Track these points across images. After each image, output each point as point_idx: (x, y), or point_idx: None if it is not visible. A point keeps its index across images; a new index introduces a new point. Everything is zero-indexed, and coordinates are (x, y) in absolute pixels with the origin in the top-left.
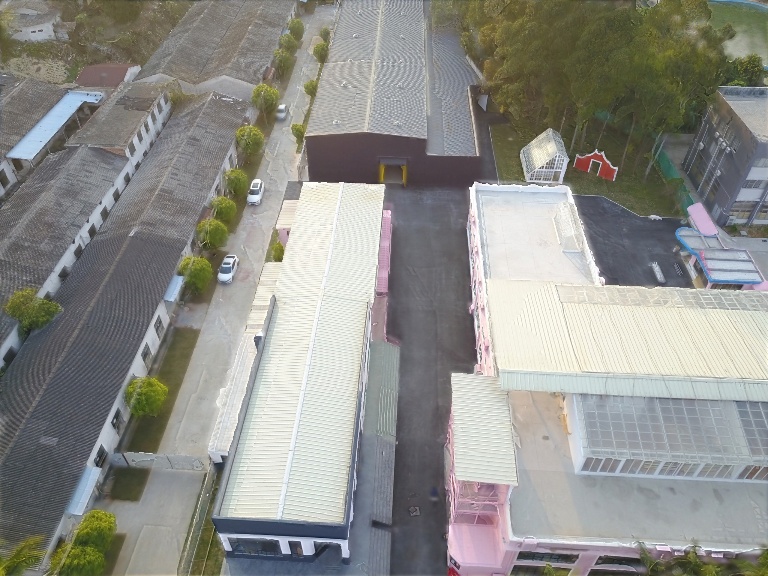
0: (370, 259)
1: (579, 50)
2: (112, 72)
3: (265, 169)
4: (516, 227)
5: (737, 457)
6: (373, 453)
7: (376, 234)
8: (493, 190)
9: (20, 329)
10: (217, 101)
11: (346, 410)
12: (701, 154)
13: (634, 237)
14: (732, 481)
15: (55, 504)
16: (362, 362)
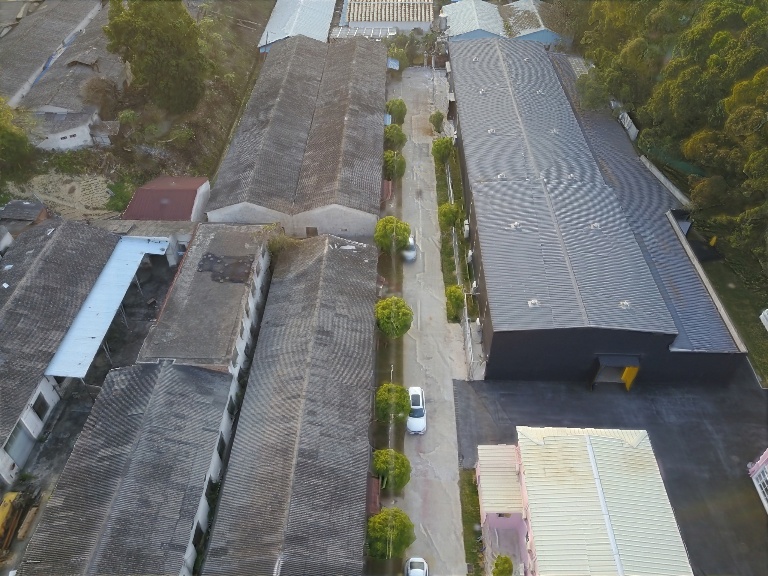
0: None
1: None
2: (176, 197)
3: (413, 356)
4: None
5: None
6: None
7: (683, 559)
8: None
9: None
10: (336, 253)
11: None
12: None
13: None
14: None
15: None
16: None
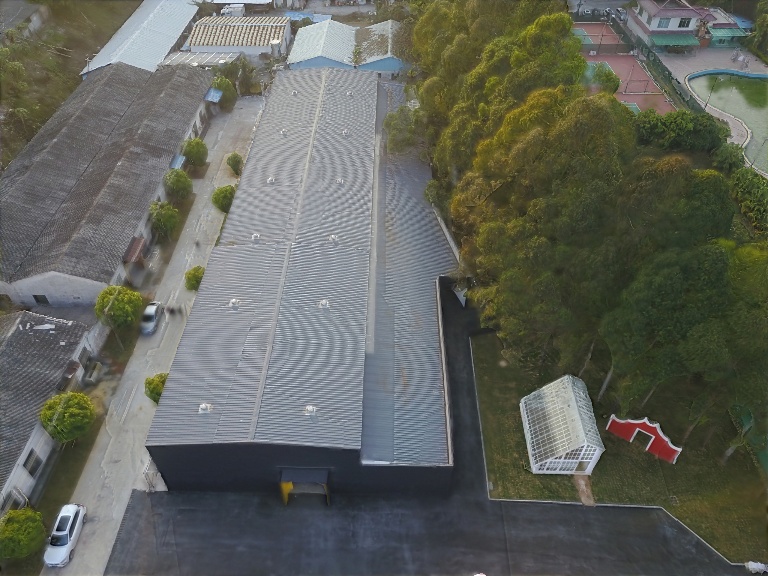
0: None
1: (629, 310)
2: None
3: (99, 458)
4: None
5: None
6: None
7: None
8: None
9: None
10: (25, 335)
11: None
12: None
13: None
14: None
15: None
16: None
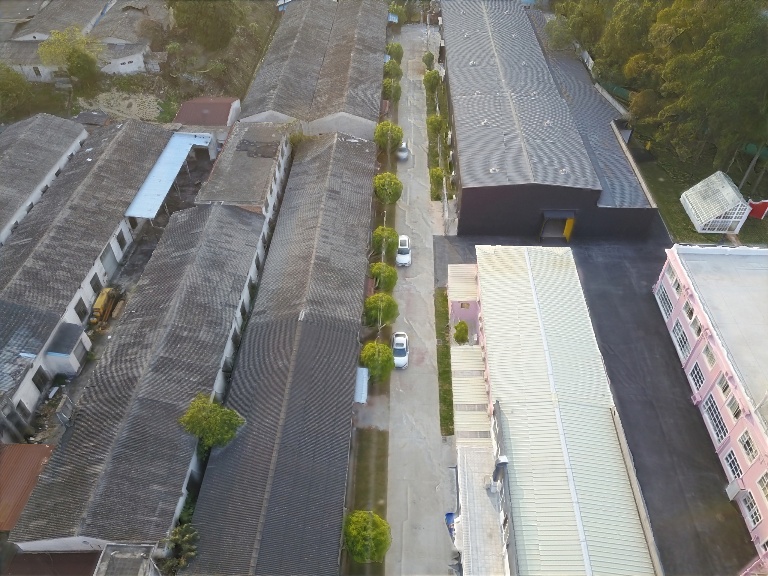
0: (591, 348)
1: None
2: (214, 108)
3: (403, 220)
4: (741, 301)
5: None
6: None
7: (585, 314)
8: (695, 253)
9: (200, 448)
10: (344, 143)
11: (642, 568)
12: None
13: None
14: None
15: None
16: (641, 498)
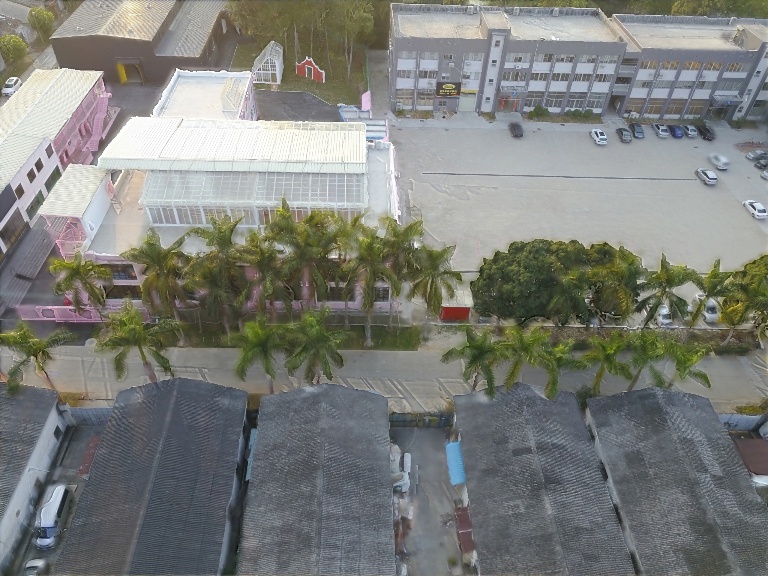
0: (64, 115)
1: None
2: None
3: (29, 73)
4: (196, 97)
5: (245, 201)
6: (34, 239)
7: (78, 101)
8: (192, 76)
9: None
10: None
11: None
12: (389, 60)
13: (318, 117)
14: (257, 226)
15: None
16: None
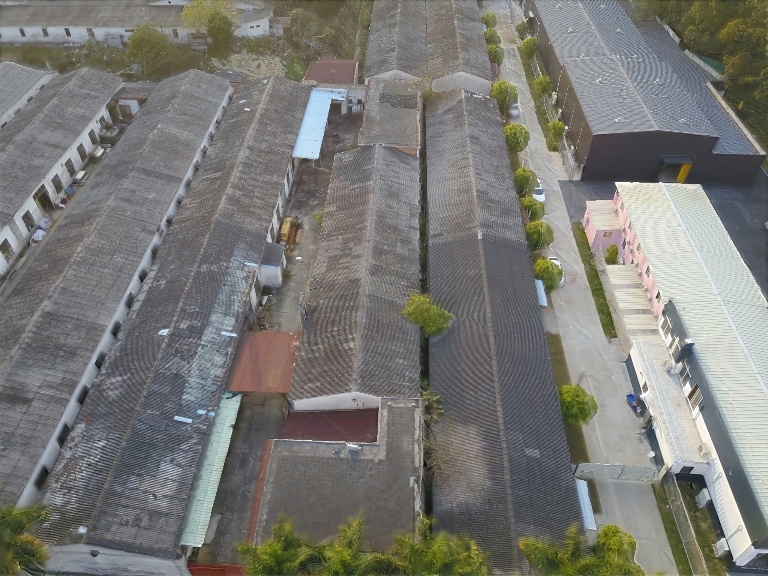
0: (738, 262)
1: None
2: (341, 68)
3: (528, 168)
4: None
5: None
6: None
7: (727, 236)
8: None
9: (421, 336)
10: (471, 98)
11: None
12: None
13: None
14: None
15: (573, 519)
16: None
